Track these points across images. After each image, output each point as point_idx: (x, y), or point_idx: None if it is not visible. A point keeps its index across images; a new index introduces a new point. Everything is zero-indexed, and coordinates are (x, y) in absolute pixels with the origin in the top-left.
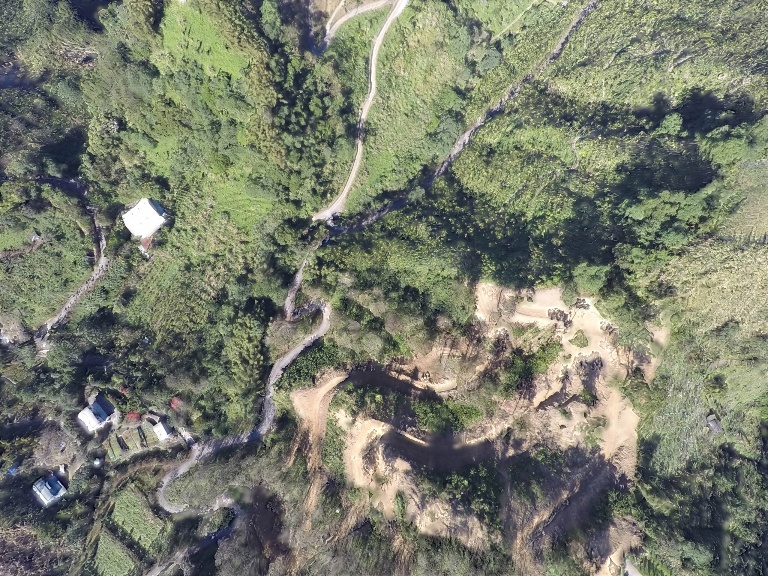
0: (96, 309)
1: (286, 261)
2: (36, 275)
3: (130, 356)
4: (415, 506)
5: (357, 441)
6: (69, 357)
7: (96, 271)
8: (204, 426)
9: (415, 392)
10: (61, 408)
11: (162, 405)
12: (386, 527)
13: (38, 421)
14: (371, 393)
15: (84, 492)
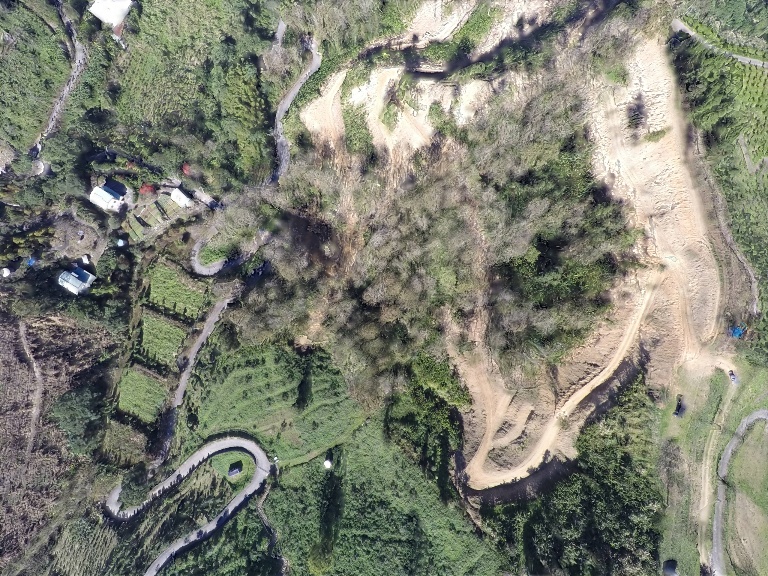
0: (83, 112)
1: (262, 24)
2: (13, 80)
3: (129, 136)
4: (450, 87)
5: (377, 98)
6: (66, 146)
7: (74, 69)
8: (222, 178)
9: (420, 50)
10: (70, 200)
11: (174, 169)
12: (429, 148)
13: (49, 222)
14: (377, 56)
15: (114, 273)
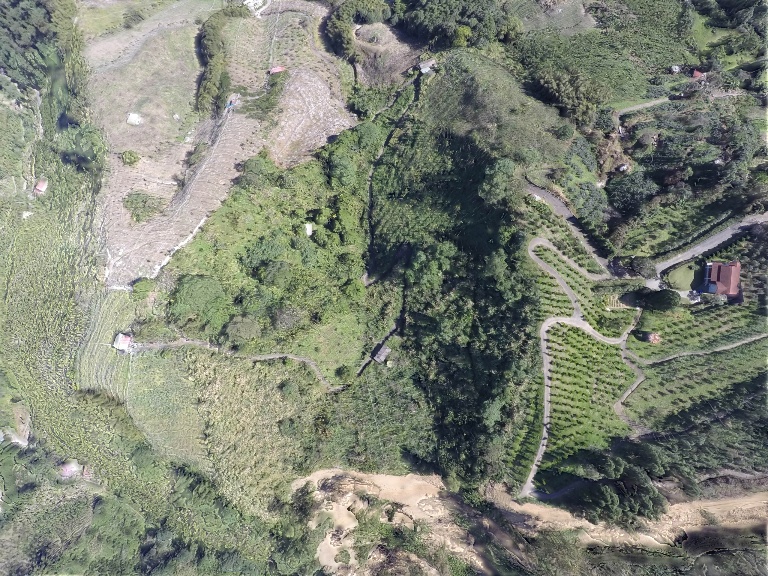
0: None
1: None
2: None
3: None
4: None
5: None
6: None
7: None
8: None
9: None
10: None
11: None
12: None
13: None
14: None
15: None
